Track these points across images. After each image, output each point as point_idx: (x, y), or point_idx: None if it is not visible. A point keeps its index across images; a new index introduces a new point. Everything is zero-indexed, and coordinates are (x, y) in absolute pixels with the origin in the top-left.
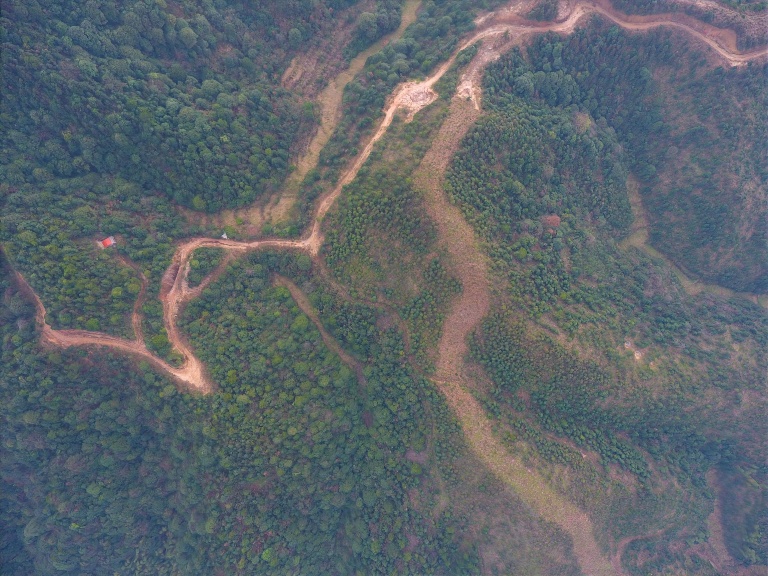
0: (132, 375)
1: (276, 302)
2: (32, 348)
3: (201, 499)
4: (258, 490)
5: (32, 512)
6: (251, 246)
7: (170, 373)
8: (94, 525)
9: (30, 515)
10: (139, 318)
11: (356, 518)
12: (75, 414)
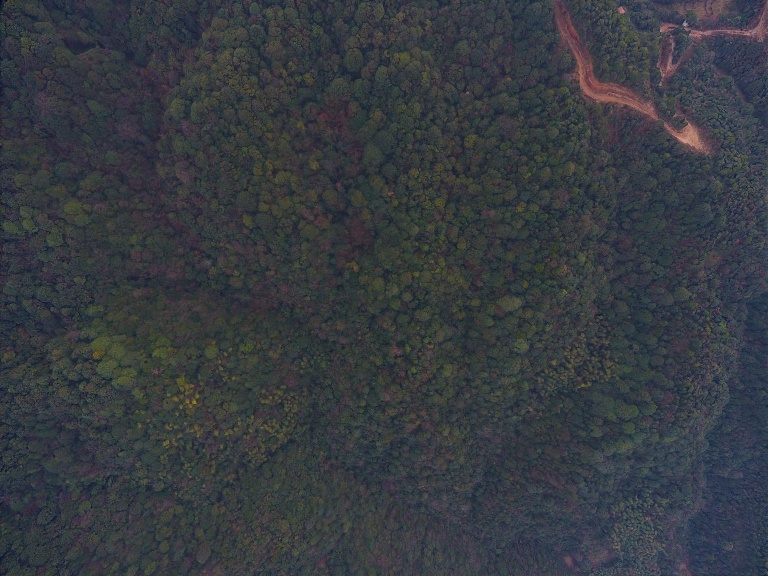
0: (639, 138)
1: (725, 89)
2: (580, 98)
3: (668, 271)
4: (712, 266)
5: (480, 302)
6: (705, 34)
7: (673, 136)
8: (567, 299)
9: (478, 305)
10: (648, 82)
11: (767, 309)
12: (591, 173)
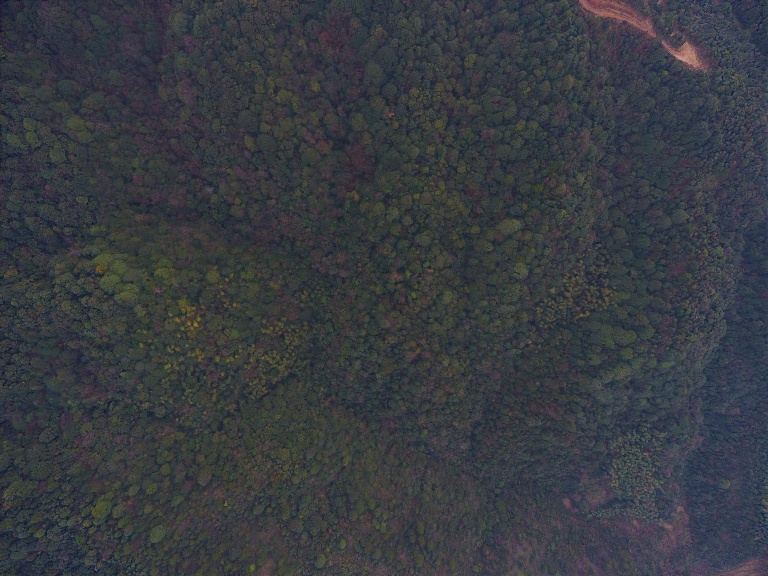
0: (637, 56)
1: (722, 15)
2: (579, 11)
3: (666, 194)
4: None
5: (479, 229)
6: None
7: (671, 54)
8: (565, 222)
9: (478, 232)
10: (647, 0)
11: (765, 240)
12: (590, 90)
